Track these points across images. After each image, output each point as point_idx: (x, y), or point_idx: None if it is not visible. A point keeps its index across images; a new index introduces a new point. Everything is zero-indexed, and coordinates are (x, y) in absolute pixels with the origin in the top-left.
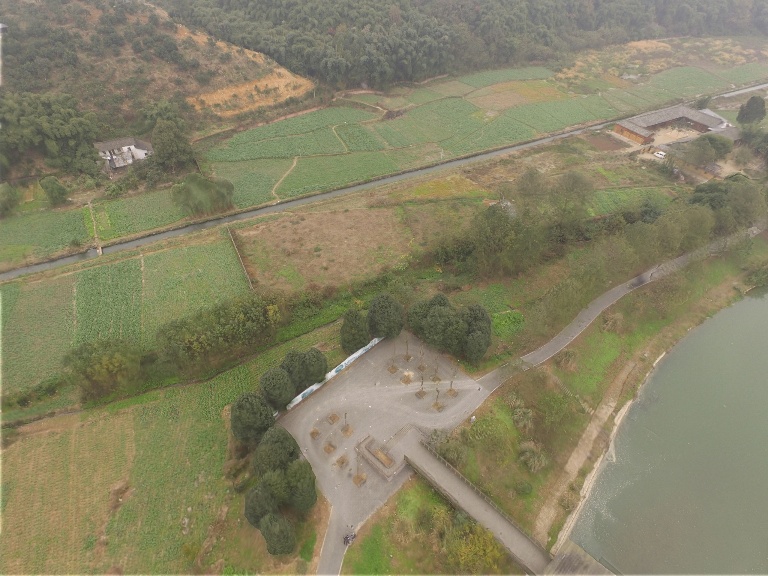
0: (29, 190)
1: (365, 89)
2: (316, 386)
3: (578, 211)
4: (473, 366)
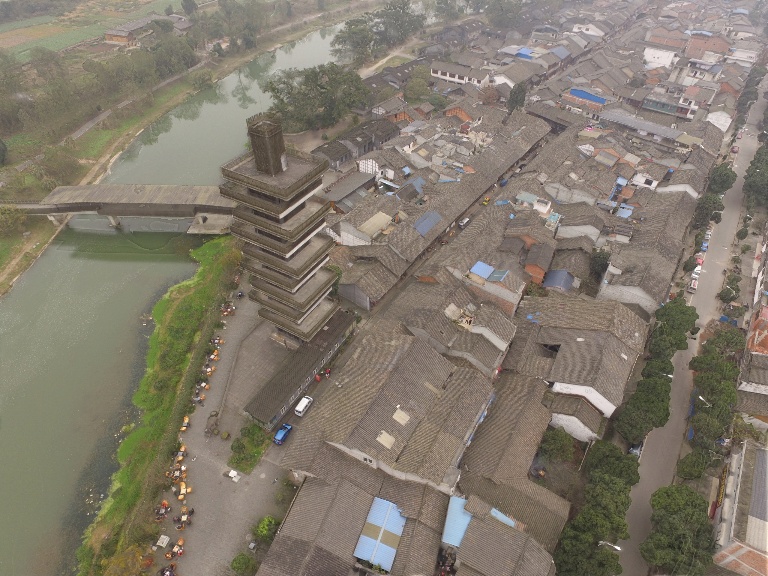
0: None
1: None
2: None
3: (63, 76)
4: (1, 167)
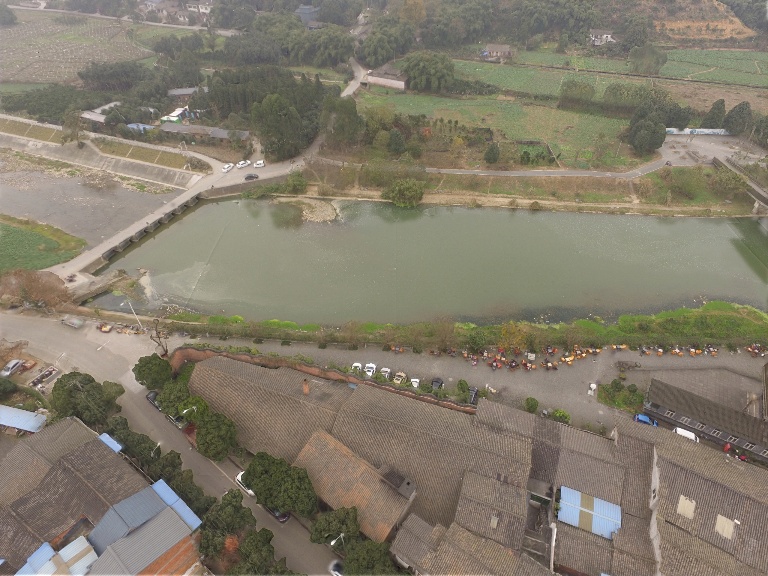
0: (546, 44)
1: None
2: (676, 132)
3: None
4: None
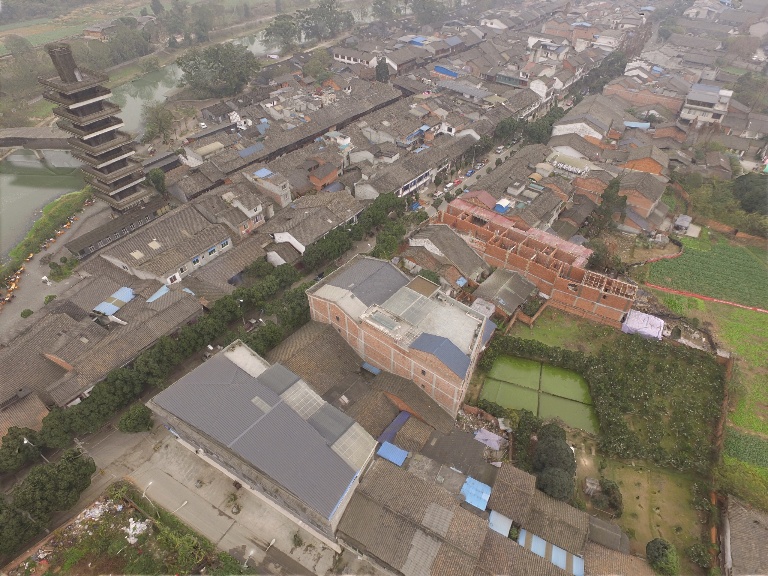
0: None
1: None
2: None
3: (33, 59)
4: None
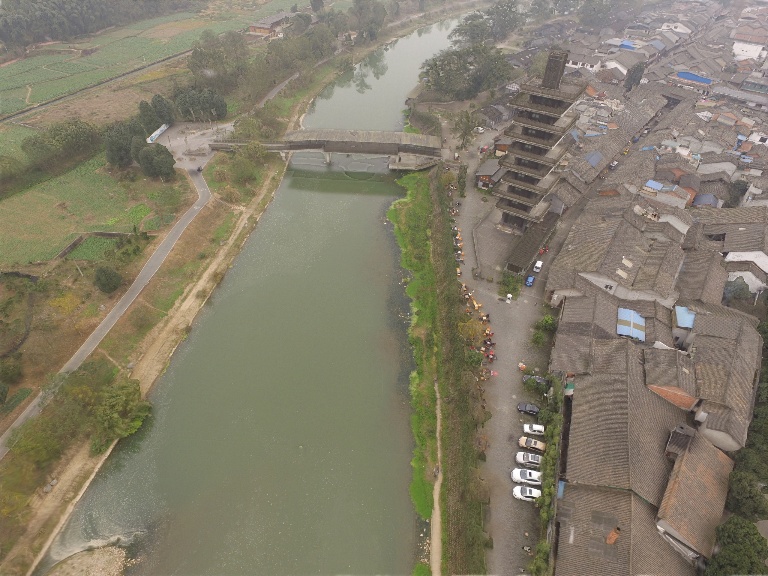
0: None
1: (51, 41)
2: None
3: (244, 56)
4: (224, 120)
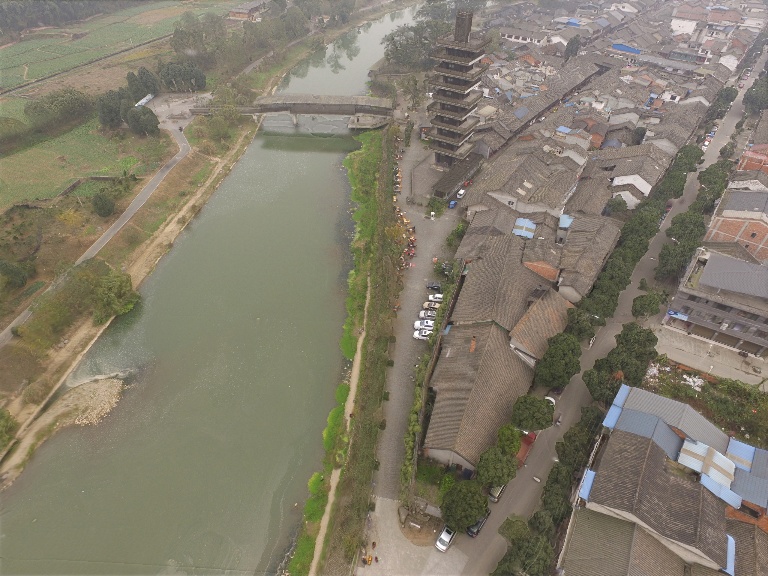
0: None
1: (43, 26)
2: None
3: (223, 36)
4: None
